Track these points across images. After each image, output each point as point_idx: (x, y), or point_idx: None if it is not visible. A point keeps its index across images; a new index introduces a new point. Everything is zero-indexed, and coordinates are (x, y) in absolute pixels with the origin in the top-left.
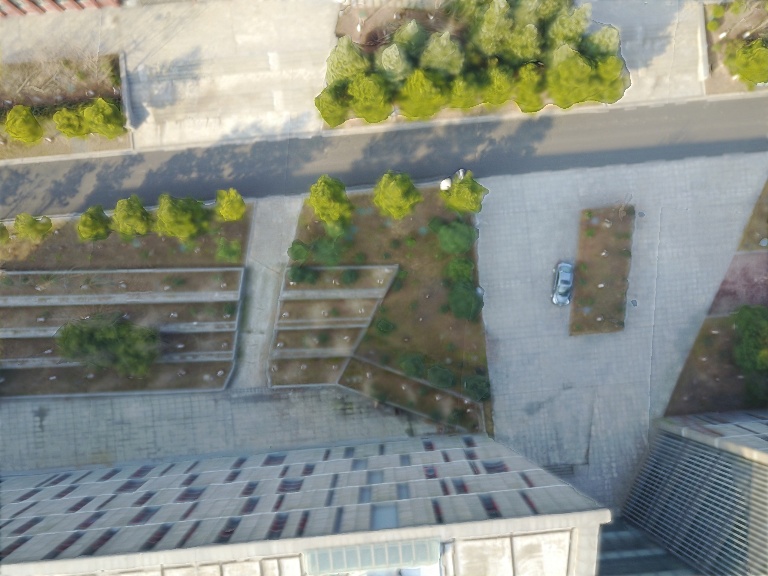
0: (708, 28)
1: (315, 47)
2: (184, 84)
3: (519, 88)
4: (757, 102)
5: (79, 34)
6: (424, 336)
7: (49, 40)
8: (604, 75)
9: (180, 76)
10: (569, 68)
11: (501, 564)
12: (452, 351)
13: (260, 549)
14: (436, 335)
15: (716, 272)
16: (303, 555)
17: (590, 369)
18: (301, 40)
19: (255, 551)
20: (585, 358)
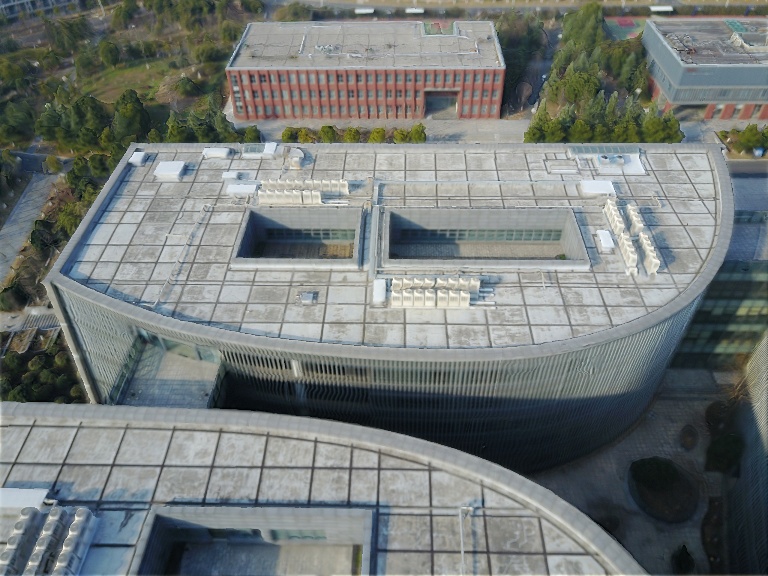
0: (720, 137)
1: (518, 134)
2: (451, 142)
3: (628, 135)
4: (759, 163)
5: (402, 125)
6: None
7: (387, 126)
8: (670, 126)
9: (449, 140)
10: (652, 120)
11: (673, 161)
12: None
13: (546, 145)
14: None
15: (766, 218)
16: (568, 151)
17: None
18: (511, 132)
19: (544, 145)
20: None
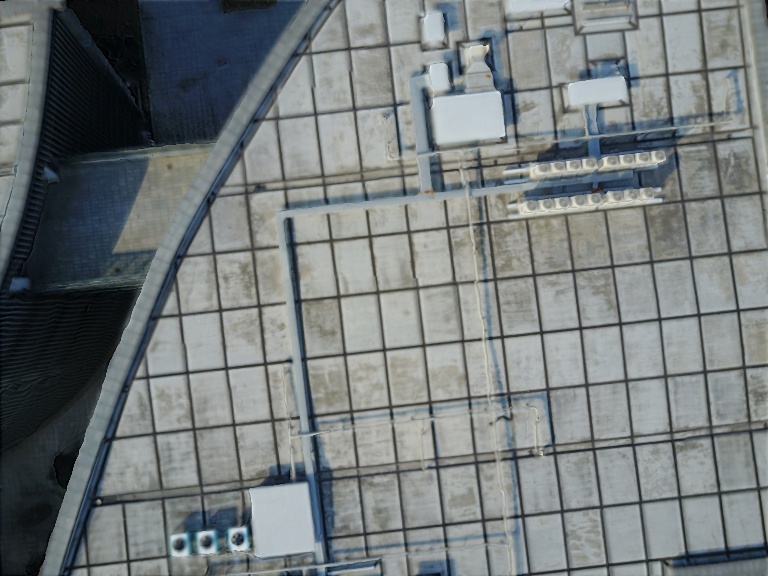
0: None
1: None
2: None
3: None
4: None
5: None
6: (80, 17)
7: None
8: None
9: None
10: None
11: None
12: (103, 27)
13: None
14: (92, 15)
15: None
16: None
17: (245, 46)
18: None
19: None
20: (239, 34)
